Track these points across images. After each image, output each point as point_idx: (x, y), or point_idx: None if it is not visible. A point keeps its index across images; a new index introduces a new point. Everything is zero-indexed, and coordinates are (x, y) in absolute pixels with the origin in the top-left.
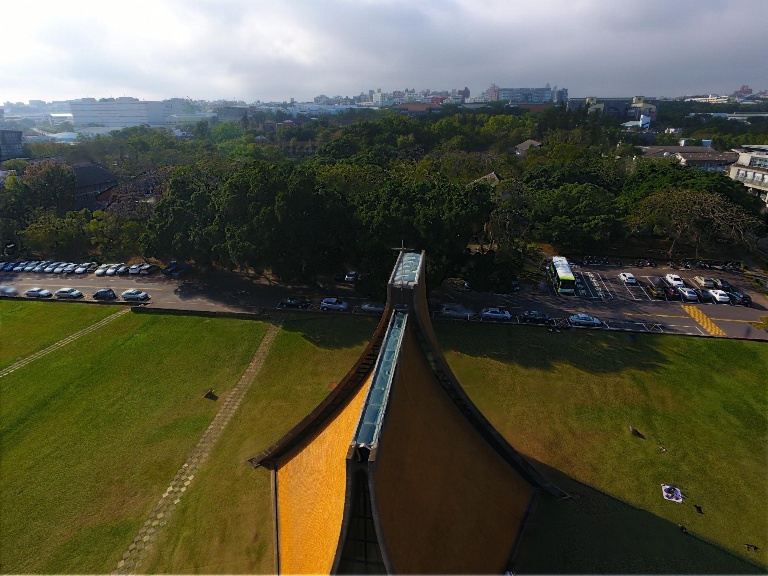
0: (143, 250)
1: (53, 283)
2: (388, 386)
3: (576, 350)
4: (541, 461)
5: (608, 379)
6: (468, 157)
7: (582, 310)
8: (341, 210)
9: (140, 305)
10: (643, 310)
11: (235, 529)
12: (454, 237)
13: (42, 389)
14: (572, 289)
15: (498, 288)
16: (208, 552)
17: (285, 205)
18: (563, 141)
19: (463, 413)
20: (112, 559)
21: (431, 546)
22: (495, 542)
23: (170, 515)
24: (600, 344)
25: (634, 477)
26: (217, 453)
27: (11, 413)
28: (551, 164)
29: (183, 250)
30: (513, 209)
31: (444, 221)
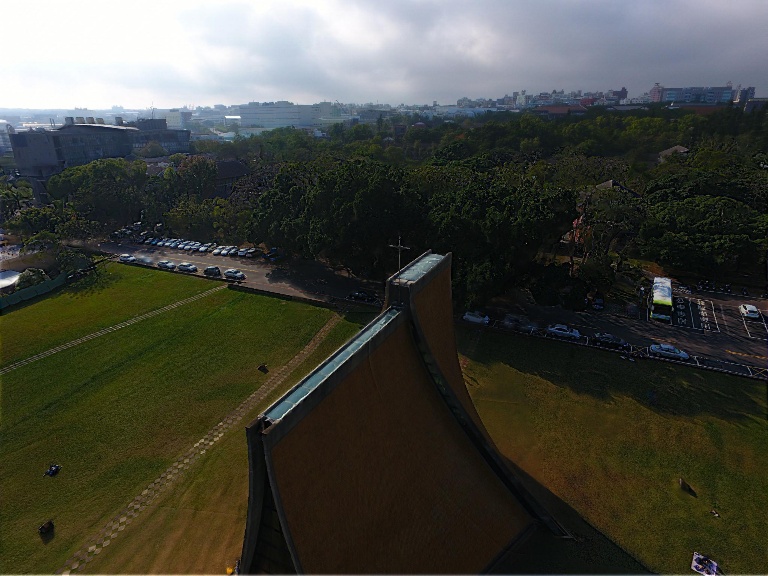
0: (246, 235)
1: (180, 258)
2: (331, 373)
3: (646, 383)
4: (555, 493)
5: (675, 422)
6: (586, 162)
7: (672, 340)
8: (417, 210)
9: (235, 283)
10: (755, 351)
11: (237, 486)
12: (522, 245)
13: (143, 342)
14: (667, 316)
15: (567, 304)
16: (209, 500)
17: (361, 202)
18: (717, 147)
19: (459, 422)
20: (140, 486)
21: (365, 539)
22: (460, 559)
23: (193, 462)
24: (679, 381)
25: (662, 536)
26: (249, 419)
27: (116, 357)
28: (684, 173)
29: (277, 238)
30: (607, 220)
31: (512, 227)
